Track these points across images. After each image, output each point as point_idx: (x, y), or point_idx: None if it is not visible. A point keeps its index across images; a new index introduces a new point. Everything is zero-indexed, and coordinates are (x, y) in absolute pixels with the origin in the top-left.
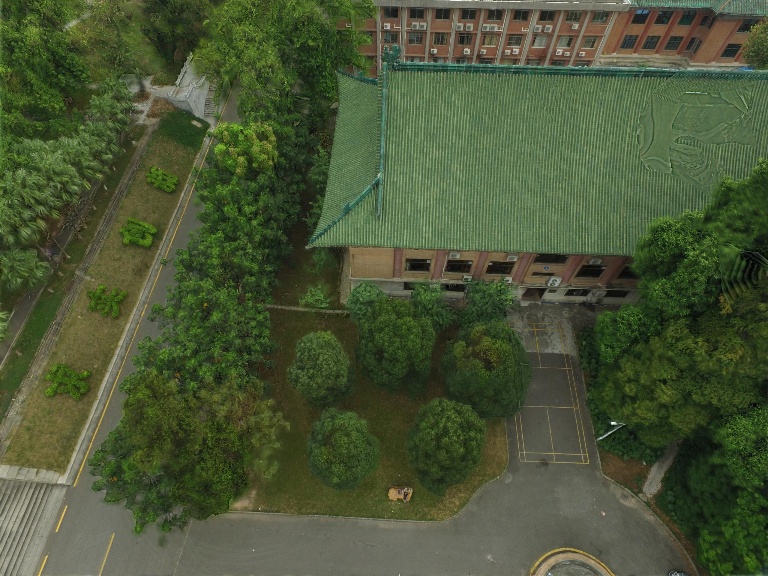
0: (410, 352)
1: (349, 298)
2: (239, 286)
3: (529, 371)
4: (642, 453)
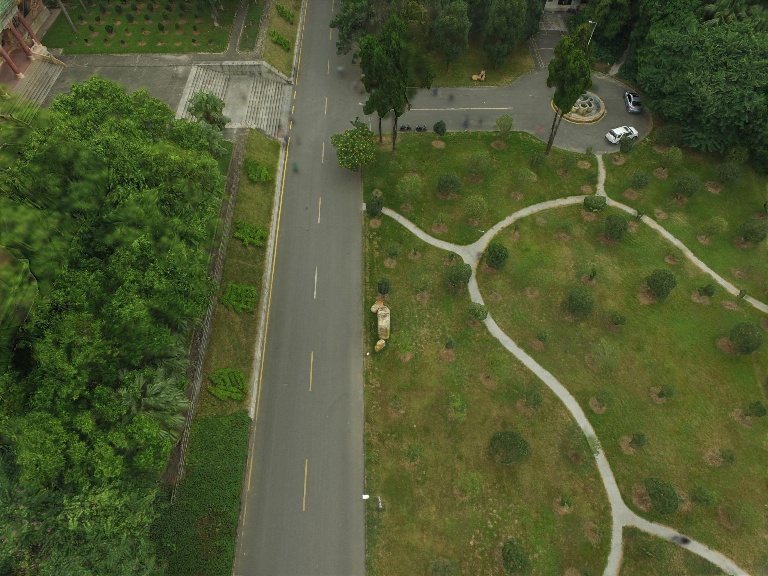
0: None
1: None
2: None
3: (541, 36)
4: (607, 57)
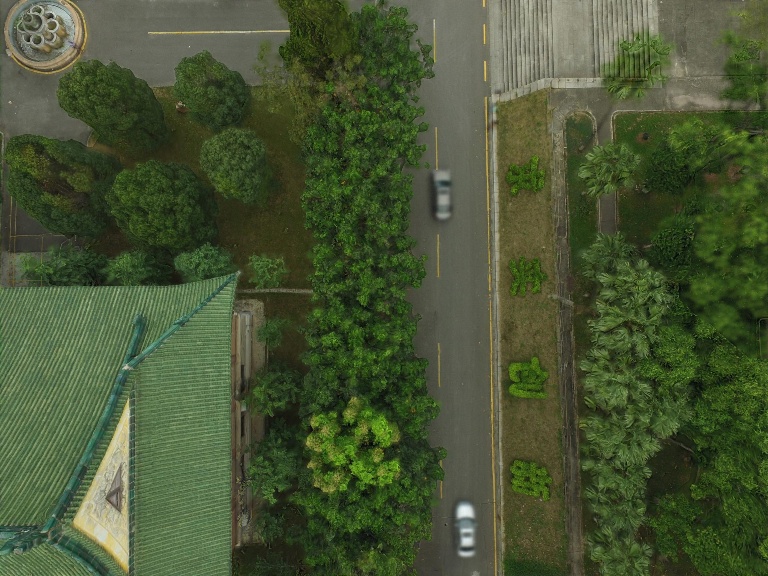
0: None
1: (223, 264)
2: (334, 244)
3: None
4: None
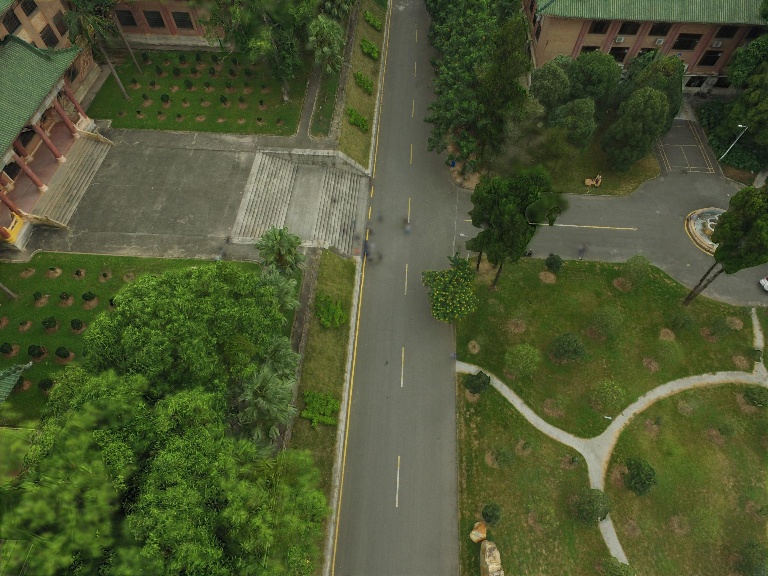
0: (610, 75)
1: None
2: None
3: None
4: (752, 164)
